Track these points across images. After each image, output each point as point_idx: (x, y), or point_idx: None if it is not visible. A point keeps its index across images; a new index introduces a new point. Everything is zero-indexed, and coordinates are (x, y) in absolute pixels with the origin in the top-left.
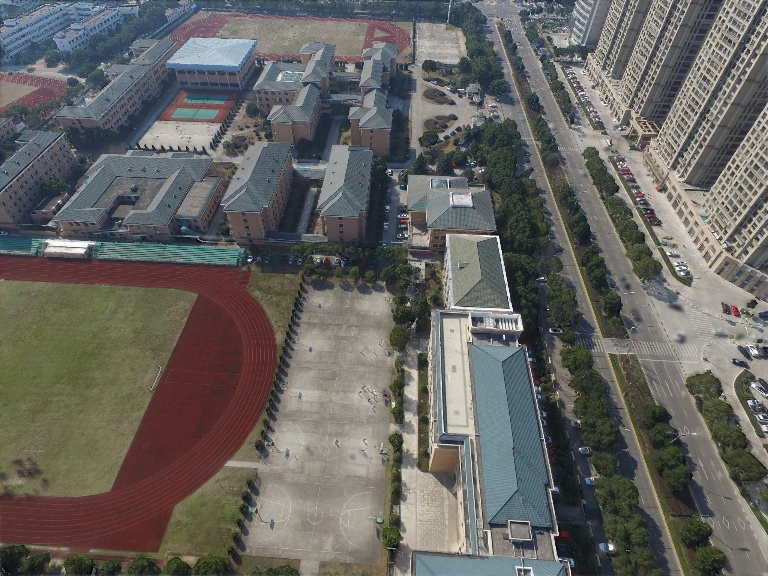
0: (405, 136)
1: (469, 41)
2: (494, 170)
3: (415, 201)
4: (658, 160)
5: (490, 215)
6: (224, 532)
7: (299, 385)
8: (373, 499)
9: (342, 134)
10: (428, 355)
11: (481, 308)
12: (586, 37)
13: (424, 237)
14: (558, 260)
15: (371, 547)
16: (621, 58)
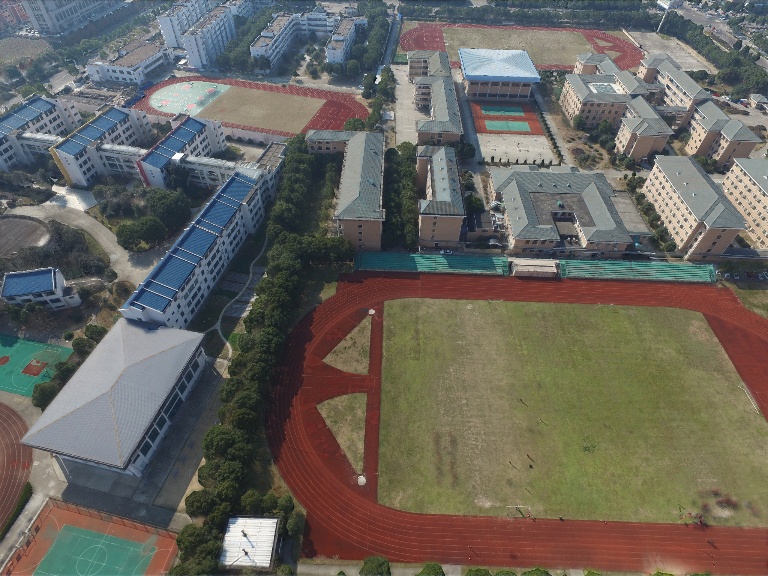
0: None
1: (710, 51)
2: None
3: None
4: None
5: None
6: None
7: None
8: None
9: (672, 146)
10: None
11: None
12: None
13: None
14: None
15: None
16: None
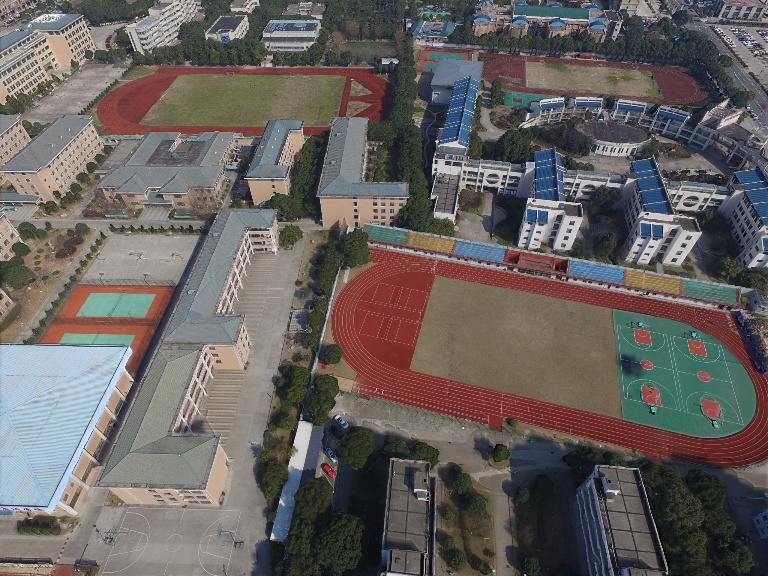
0: None
1: None
2: None
3: None
4: None
5: None
6: None
7: None
8: None
9: None
10: None
11: None
12: None
13: None
14: None
15: None
16: None
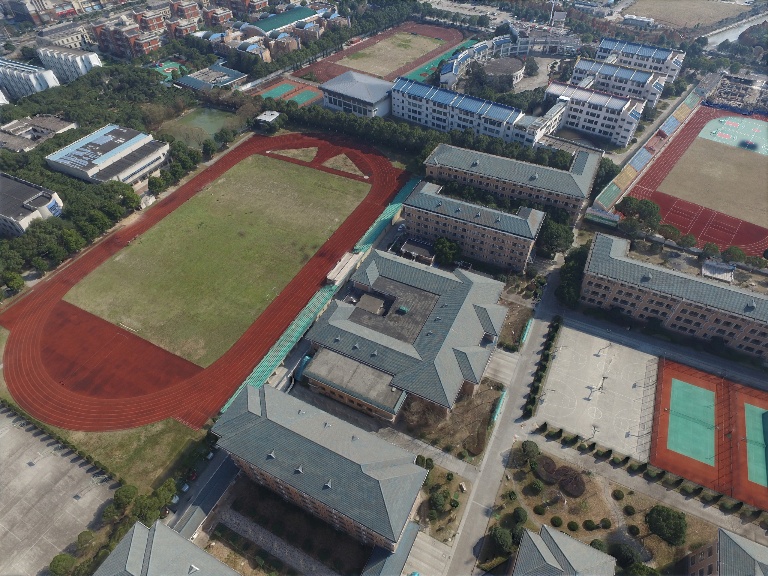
0: None
1: None
2: None
3: None
4: None
5: None
6: None
7: (5, 439)
8: None
9: None
10: None
11: None
12: None
13: None
14: None
15: None
16: None
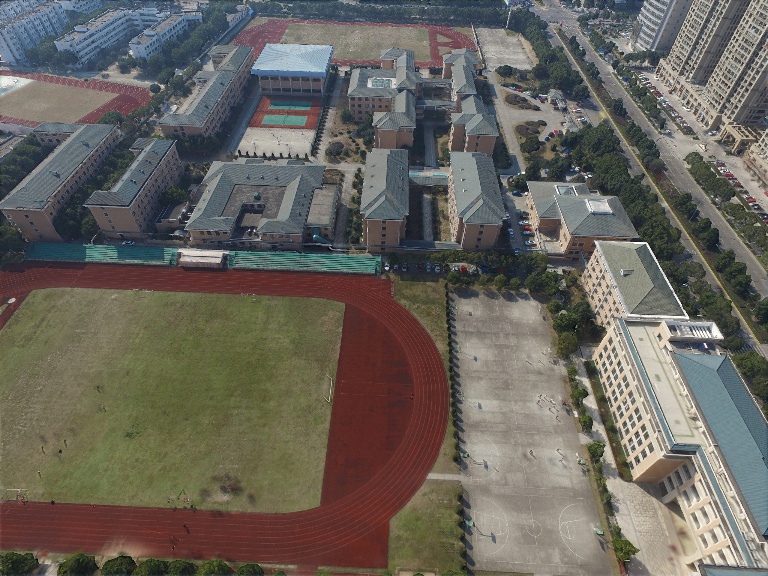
0: (501, 142)
1: (537, 47)
2: (607, 176)
3: (545, 208)
4: (765, 165)
5: (628, 221)
6: (448, 546)
7: (475, 395)
8: (586, 510)
9: (437, 140)
10: (595, 363)
11: (657, 316)
12: (656, 43)
13: (556, 244)
14: (701, 266)
15: (600, 559)
16: (703, 64)
